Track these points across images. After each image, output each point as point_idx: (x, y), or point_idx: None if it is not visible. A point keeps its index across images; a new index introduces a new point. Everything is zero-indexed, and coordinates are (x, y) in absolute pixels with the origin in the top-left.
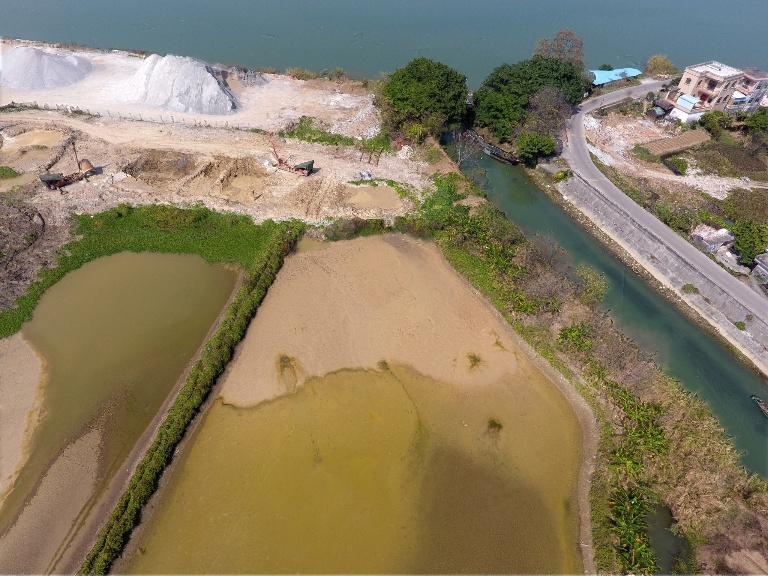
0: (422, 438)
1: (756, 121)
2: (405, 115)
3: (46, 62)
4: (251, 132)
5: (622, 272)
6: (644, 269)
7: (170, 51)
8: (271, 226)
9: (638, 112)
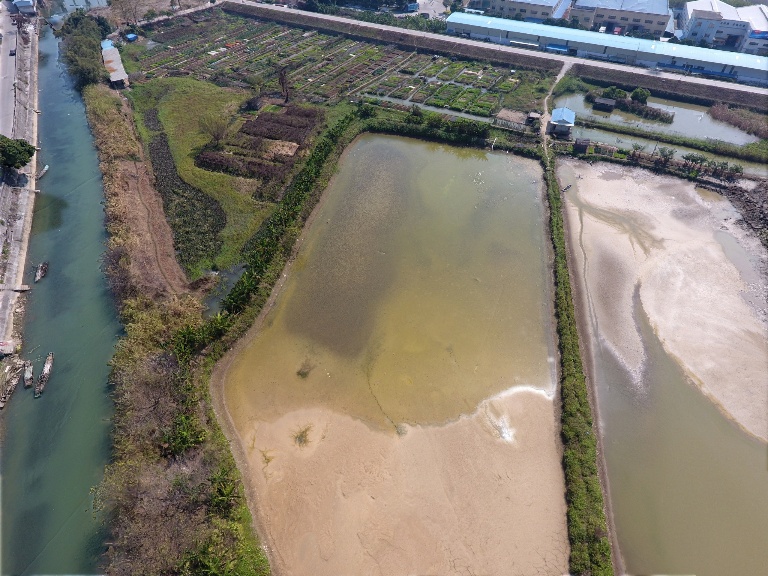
0: (367, 364)
1: None
2: None
3: None
4: None
5: None
6: None
7: None
8: None
9: None
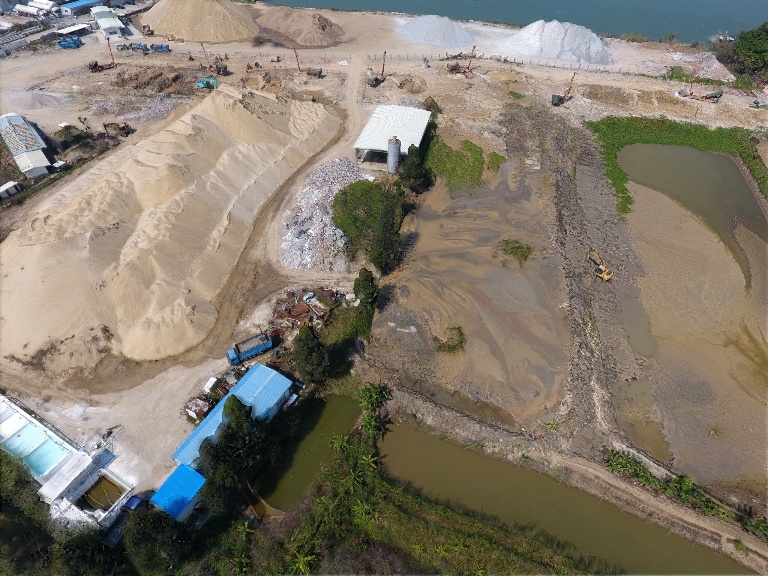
0: None
1: None
2: (763, 63)
3: (456, 26)
4: (640, 76)
5: None
6: None
7: (549, 18)
8: (724, 131)
9: None
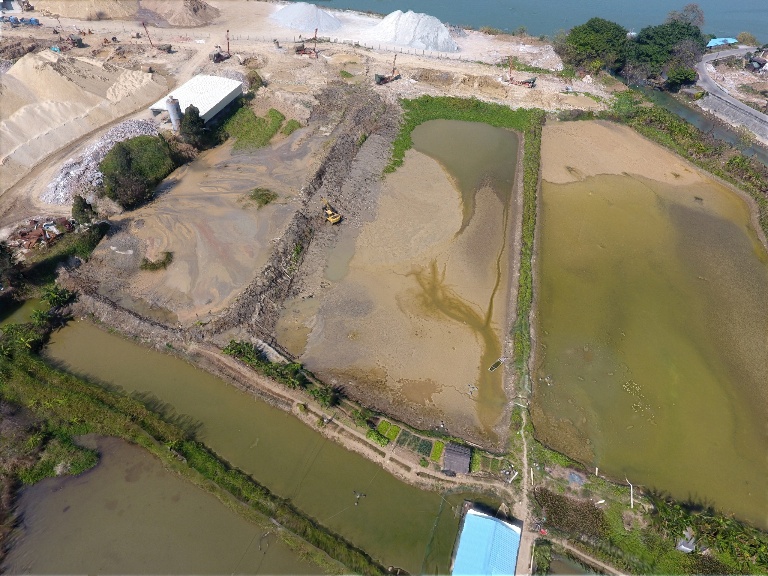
0: (661, 200)
1: None
2: (586, 55)
3: (321, 13)
4: (477, 63)
5: (751, 146)
6: (765, 144)
7: None
8: (524, 111)
9: (739, 66)
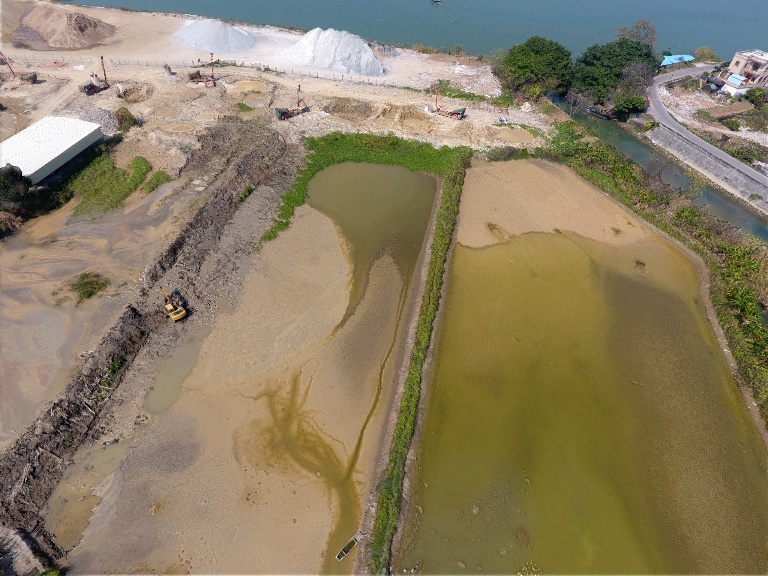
0: (596, 267)
1: None
2: (525, 79)
3: (230, 31)
4: (404, 89)
5: (704, 188)
6: (720, 186)
7: (329, 26)
8: (448, 150)
9: (696, 87)
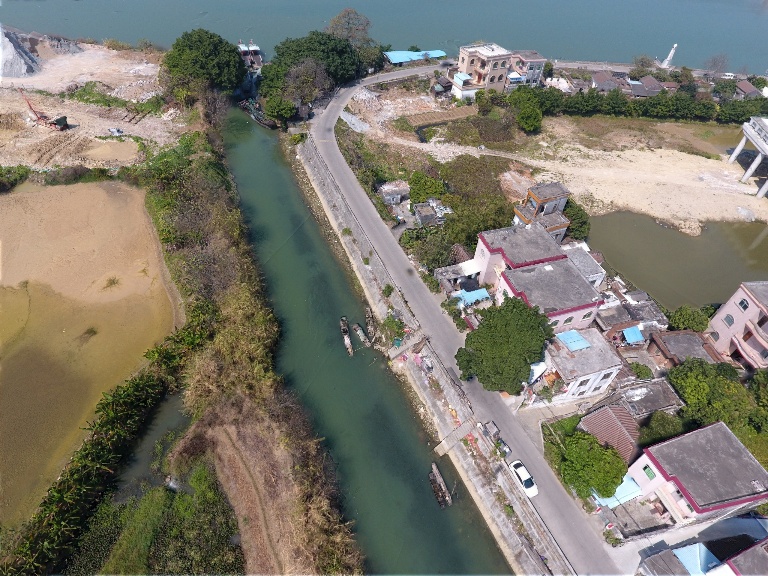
0: (16, 340)
1: (511, 97)
2: (176, 81)
3: None
4: (34, 93)
5: (305, 219)
6: (326, 216)
7: None
8: None
9: (423, 89)
